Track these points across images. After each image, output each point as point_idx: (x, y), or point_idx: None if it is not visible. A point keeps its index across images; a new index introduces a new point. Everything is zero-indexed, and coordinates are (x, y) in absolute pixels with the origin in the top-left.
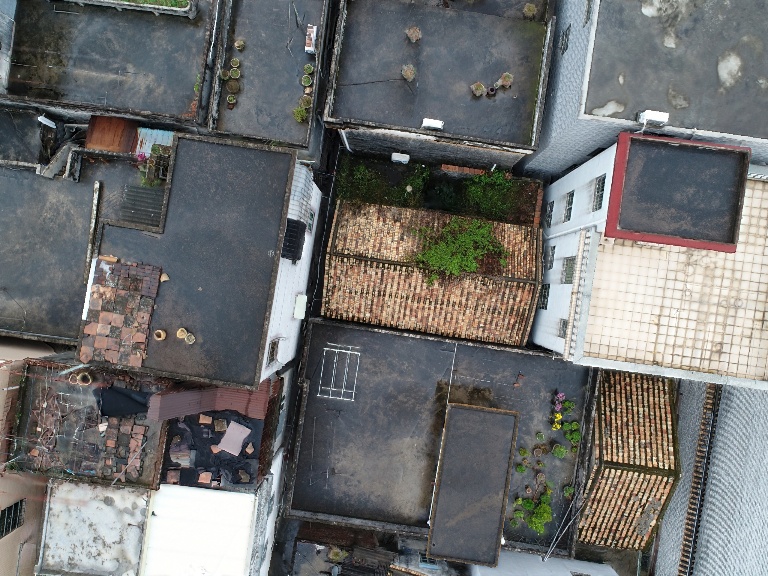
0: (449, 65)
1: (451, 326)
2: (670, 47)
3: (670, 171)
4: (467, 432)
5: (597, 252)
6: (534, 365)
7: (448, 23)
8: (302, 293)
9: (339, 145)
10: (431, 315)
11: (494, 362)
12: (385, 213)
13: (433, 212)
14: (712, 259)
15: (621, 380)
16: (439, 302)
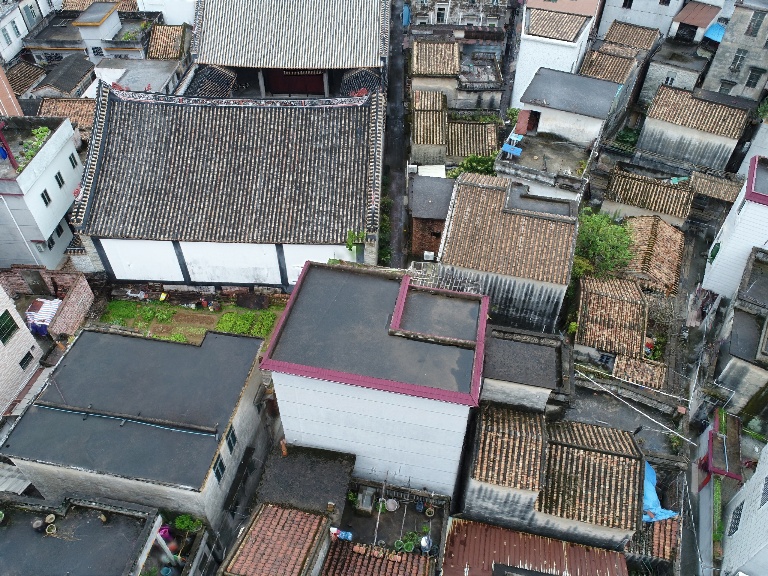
0: None
1: None
2: None
3: None
4: None
5: None
6: None
7: None
8: (54, 7)
9: None
10: None
11: None
12: None
13: None
14: None
15: None
16: None
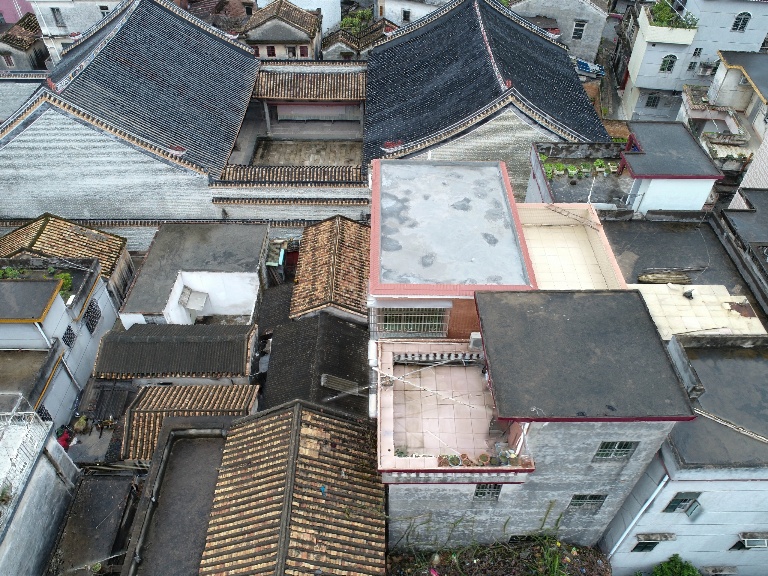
0: None
1: None
2: None
3: None
4: None
5: None
6: None
7: None
8: None
9: None
10: None
11: None
12: None
13: None
14: None
15: None
16: None
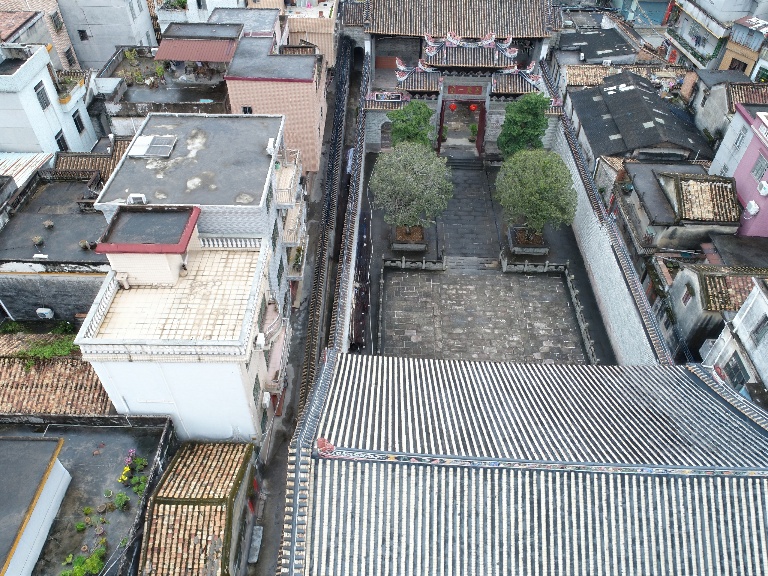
0: (69, 237)
1: (43, 407)
2: (160, 178)
3: (146, 220)
4: (7, 459)
5: (124, 293)
6: (117, 435)
7: (75, 220)
8: None
9: (5, 317)
10: (26, 399)
11: (80, 437)
12: (13, 337)
13: (53, 334)
14: (208, 290)
15: (204, 448)
16: (34, 386)
